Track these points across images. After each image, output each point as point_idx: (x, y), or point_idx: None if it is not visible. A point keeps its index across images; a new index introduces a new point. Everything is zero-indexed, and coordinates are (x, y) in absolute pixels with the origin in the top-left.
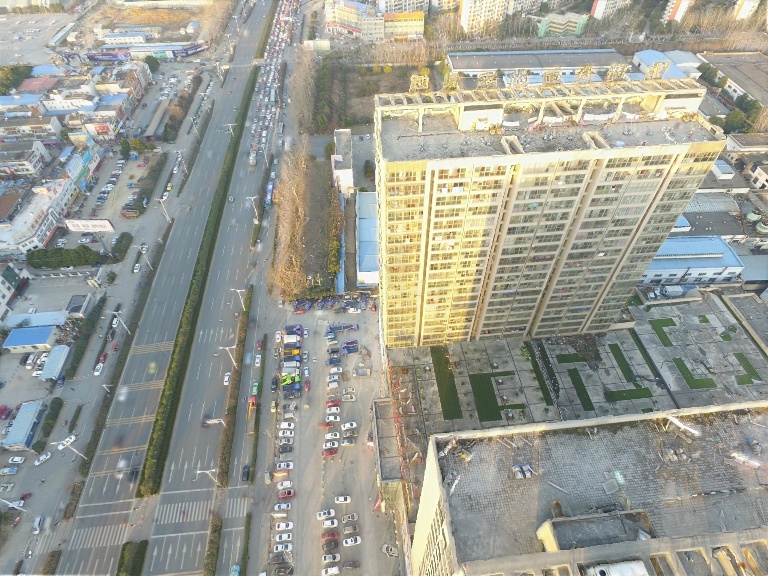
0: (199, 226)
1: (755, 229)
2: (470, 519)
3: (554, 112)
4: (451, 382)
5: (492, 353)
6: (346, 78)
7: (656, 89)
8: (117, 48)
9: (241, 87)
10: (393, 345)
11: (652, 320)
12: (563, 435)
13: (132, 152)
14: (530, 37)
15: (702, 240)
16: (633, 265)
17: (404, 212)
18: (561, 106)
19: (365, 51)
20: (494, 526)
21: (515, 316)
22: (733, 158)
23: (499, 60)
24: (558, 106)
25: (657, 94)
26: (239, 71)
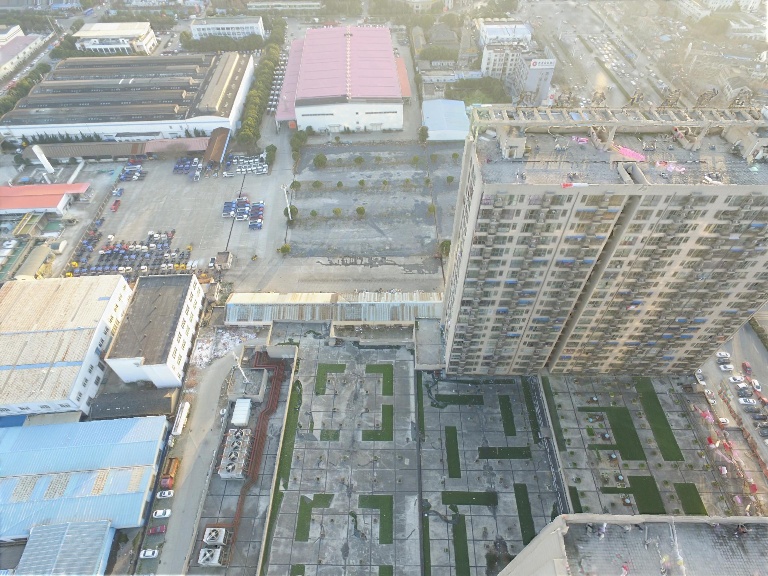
0: None
1: None
2: None
3: None
4: None
5: None
6: None
7: None
8: None
9: None
10: None
11: None
12: None
13: None
14: None
15: None
16: None
17: None
18: None
19: None
20: None
21: None
22: None
23: None
24: None
25: None
26: None
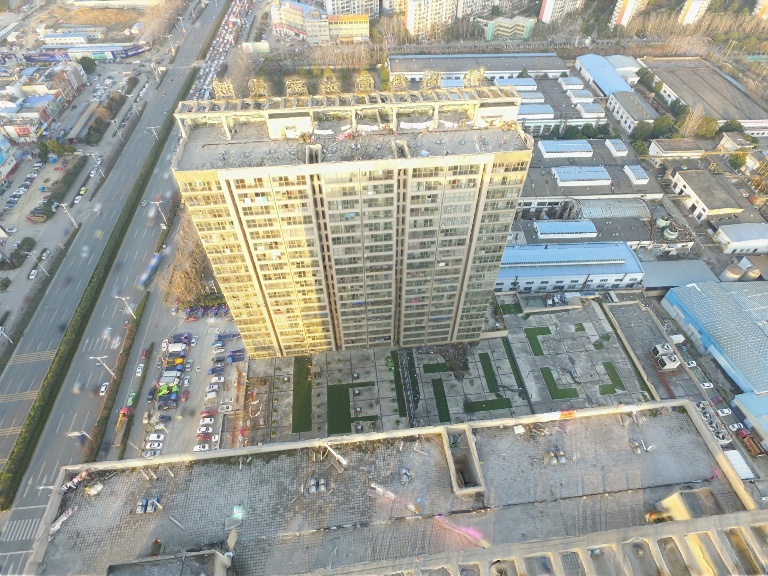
0: (106, 231)
1: (663, 235)
2: (65, 559)
3: (377, 120)
4: (307, 393)
5: (356, 363)
6: (285, 80)
7: (472, 97)
8: (57, 48)
9: (176, 89)
10: (255, 355)
11: (528, 328)
12: (212, 465)
13: (50, 155)
14: (477, 40)
15: (608, 246)
16: (481, 275)
17: (212, 222)
18: (386, 114)
19: (309, 53)
20: (86, 567)
21: (375, 326)
22: (657, 163)
23: (438, 63)
24: (380, 114)
25: (470, 102)
26: (178, 73)
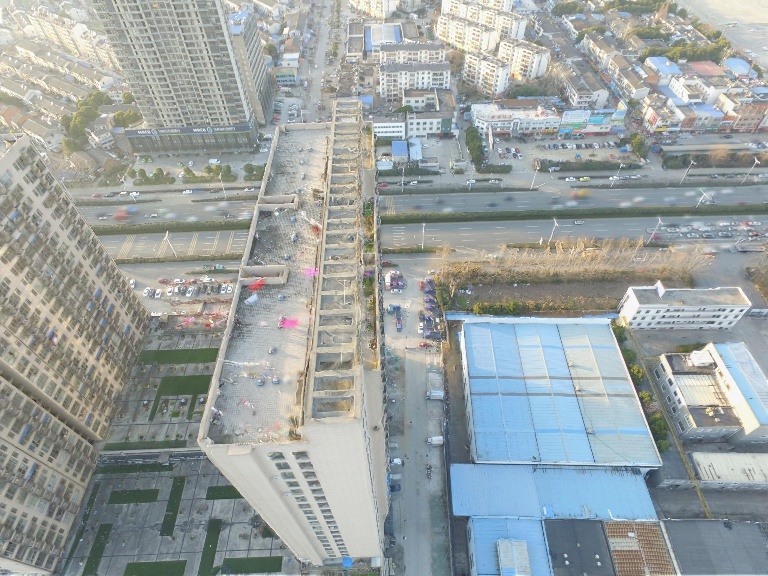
0: (531, 207)
1: None
2: None
3: None
4: None
5: None
6: None
7: (331, 346)
8: None
9: None
10: None
11: None
12: None
13: (628, 145)
14: None
15: None
16: None
17: None
18: None
19: None
20: None
21: None
22: None
23: None
24: None
25: None
26: None
